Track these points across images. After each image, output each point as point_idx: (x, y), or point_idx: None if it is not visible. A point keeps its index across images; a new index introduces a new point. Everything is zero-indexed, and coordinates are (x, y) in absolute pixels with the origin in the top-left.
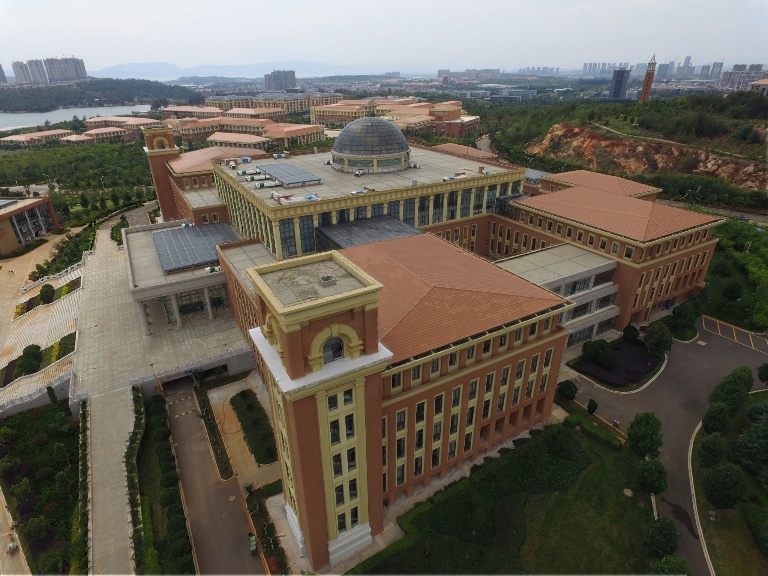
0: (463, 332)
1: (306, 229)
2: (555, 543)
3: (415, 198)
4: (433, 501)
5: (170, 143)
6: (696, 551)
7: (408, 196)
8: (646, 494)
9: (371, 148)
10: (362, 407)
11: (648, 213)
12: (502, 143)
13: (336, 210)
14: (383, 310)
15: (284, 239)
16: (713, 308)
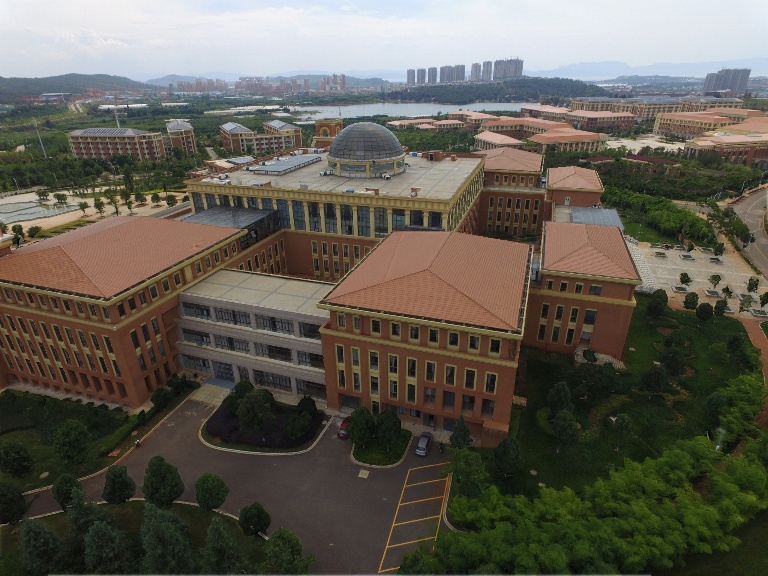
0: (26, 279)
1: (213, 205)
2: None
3: (303, 202)
4: None
5: (331, 133)
6: None
7: (295, 198)
8: (42, 485)
9: (337, 151)
10: None
11: (395, 277)
12: None
13: (232, 195)
14: (33, 249)
15: (198, 208)
16: None
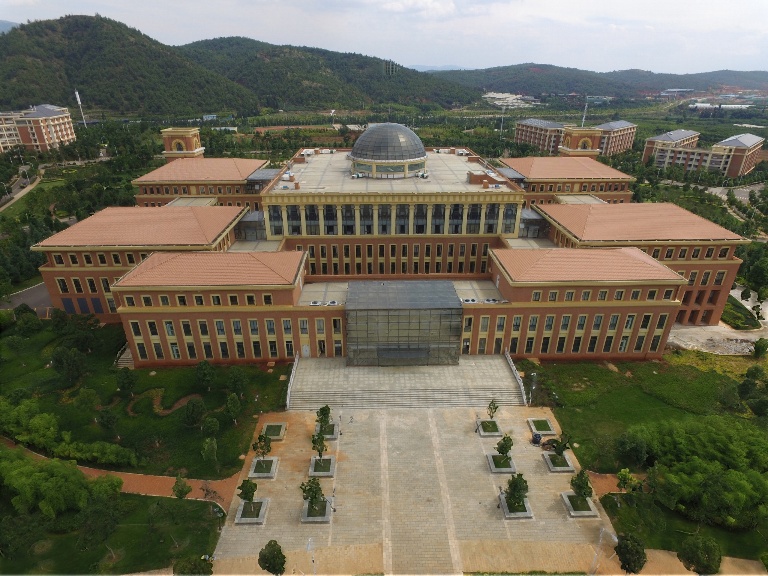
0: None
1: None
2: None
3: None
4: None
5: None
6: None
7: None
8: None
9: None
10: None
11: None
12: None
13: None
14: None
15: None
16: (48, 325)
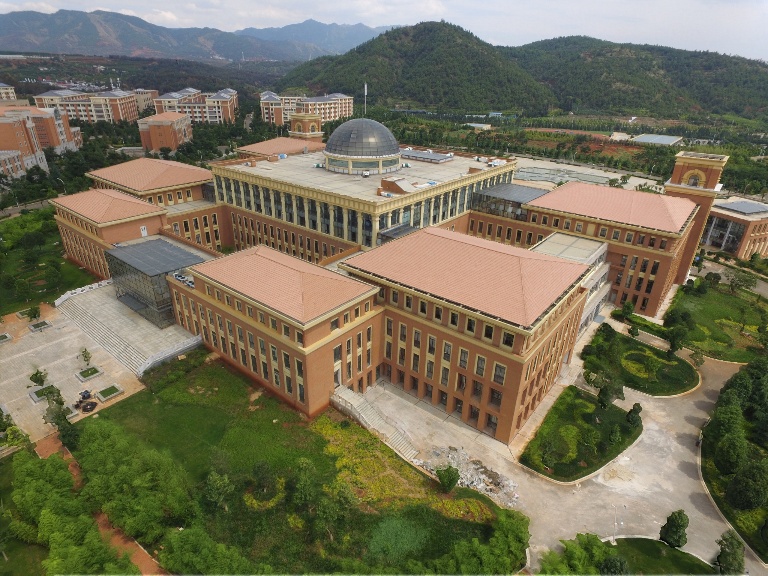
0: None
1: None
2: None
3: None
4: None
5: None
6: None
7: None
8: None
9: None
10: None
11: None
12: None
13: None
14: None
15: None
16: None
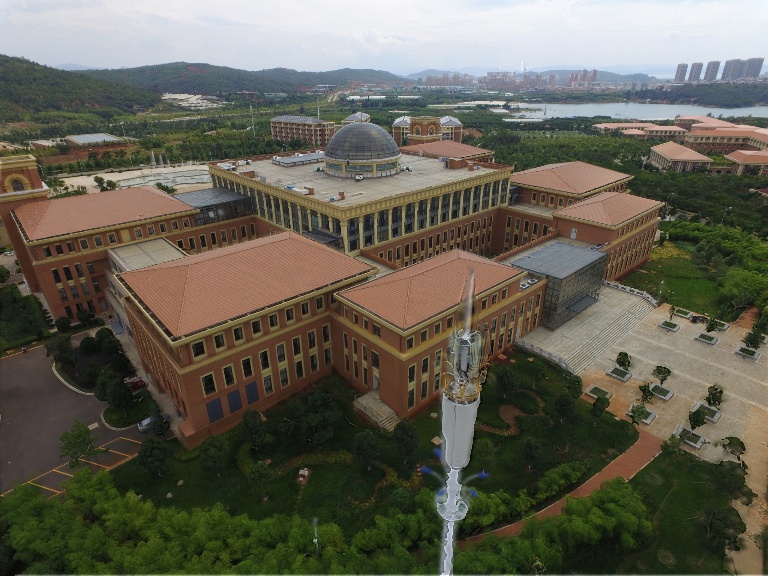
0: None
1: None
2: None
3: (262, 192)
4: (33, 300)
5: (422, 131)
6: None
7: (258, 188)
8: None
9: None
10: (1, 216)
11: None
12: None
13: None
14: None
15: None
16: None
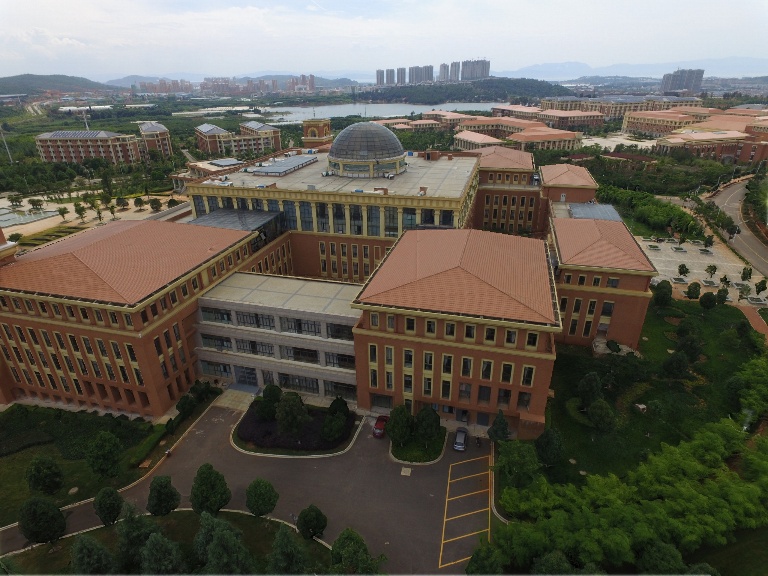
0: (39, 288)
1: (215, 207)
2: (1, 471)
3: (311, 202)
4: None
5: (319, 133)
6: (2, 549)
7: (303, 199)
8: (73, 501)
9: (340, 151)
10: None
11: (427, 275)
12: (764, 180)
13: (235, 197)
14: None
15: (199, 211)
16: None
